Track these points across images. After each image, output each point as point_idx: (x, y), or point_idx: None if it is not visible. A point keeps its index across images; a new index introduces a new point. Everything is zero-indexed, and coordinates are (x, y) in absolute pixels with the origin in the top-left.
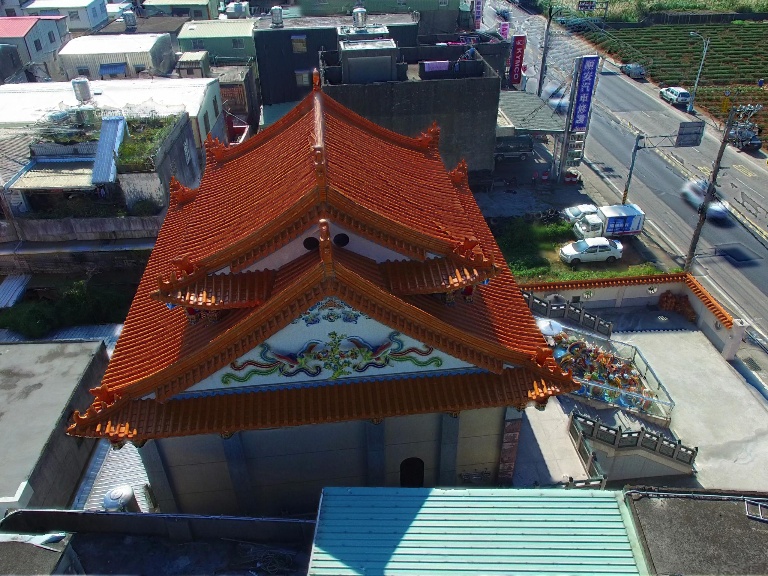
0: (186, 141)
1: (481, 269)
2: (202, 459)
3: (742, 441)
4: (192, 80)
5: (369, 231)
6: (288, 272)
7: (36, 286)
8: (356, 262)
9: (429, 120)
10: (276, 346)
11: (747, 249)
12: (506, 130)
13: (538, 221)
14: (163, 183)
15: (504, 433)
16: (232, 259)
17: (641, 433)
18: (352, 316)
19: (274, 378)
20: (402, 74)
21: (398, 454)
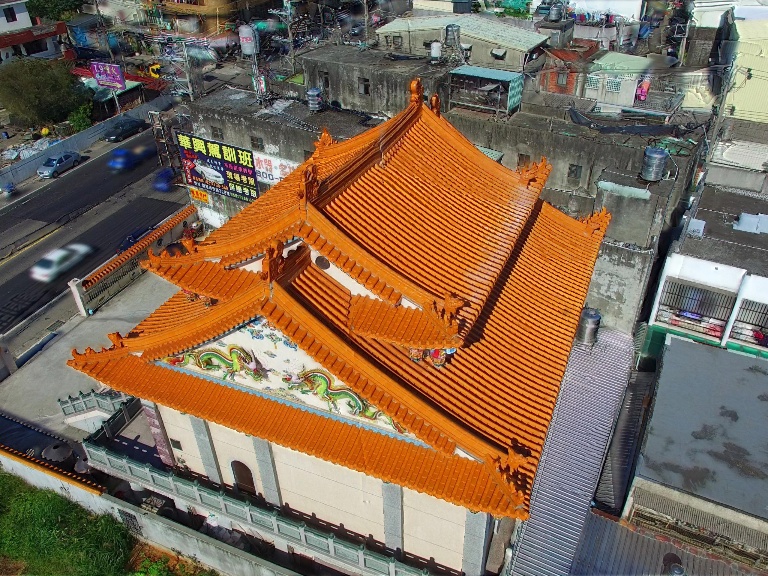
0: None
1: None
2: None
3: (124, 320)
4: None
5: None
6: None
7: None
8: None
9: None
10: None
11: None
12: None
13: None
14: None
15: None
16: None
17: None
18: None
19: None
20: None
21: None
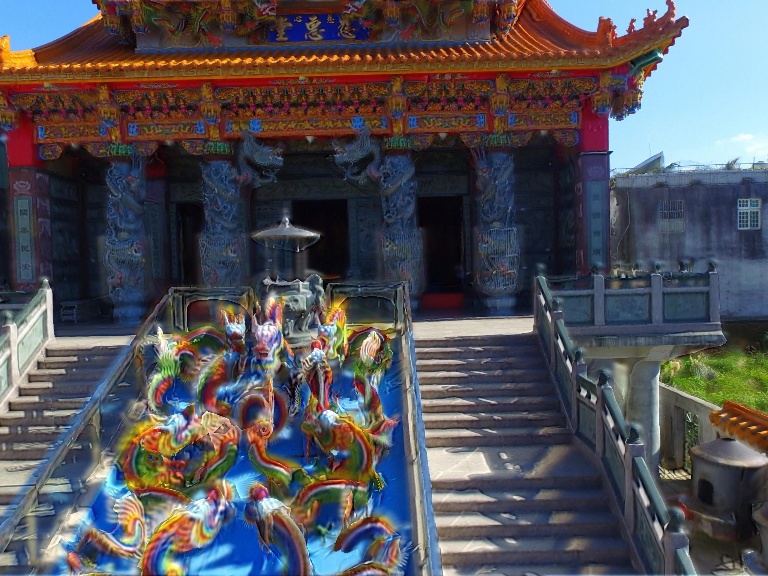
0: (759, 202)
1: None
2: None
3: None
4: None
5: None
6: None
7: None
8: None
9: None
10: None
11: None
12: None
13: None
14: (624, 208)
15: None
16: None
17: None
18: None
19: None
20: None
21: None
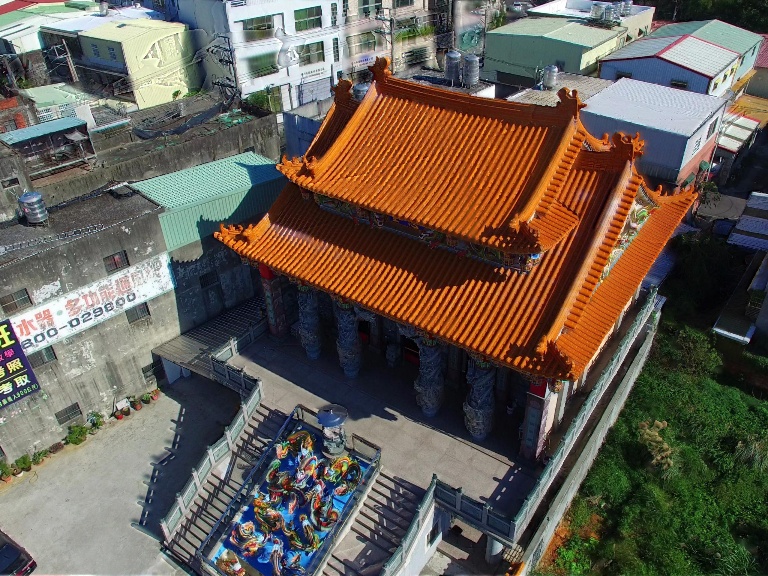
0: None
1: None
2: None
3: None
4: None
5: None
6: None
7: (757, 254)
8: None
9: None
10: None
11: None
12: None
13: None
14: None
15: None
16: None
17: None
18: None
19: None
20: None
21: None
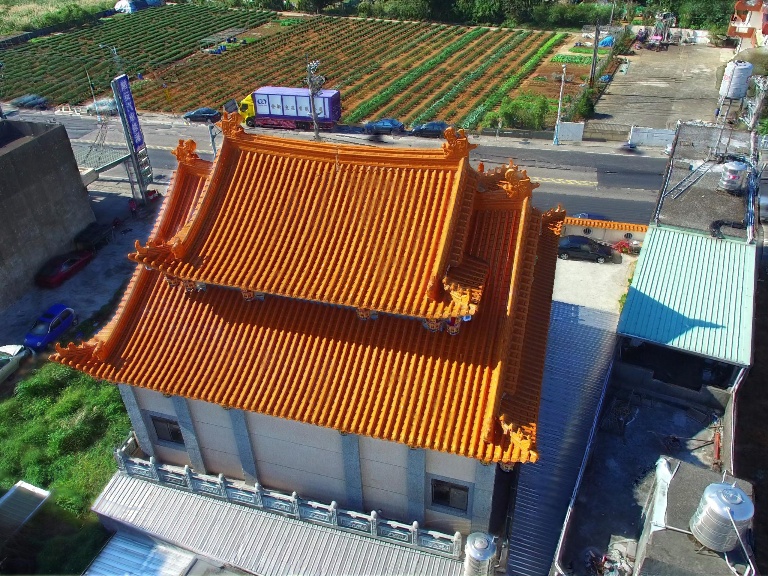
0: None
1: None
2: None
3: None
4: None
5: None
6: (471, 242)
7: None
8: None
9: (21, 199)
10: None
11: None
12: (89, 176)
13: None
14: None
15: None
16: (448, 258)
17: None
18: None
19: None
20: None
21: None
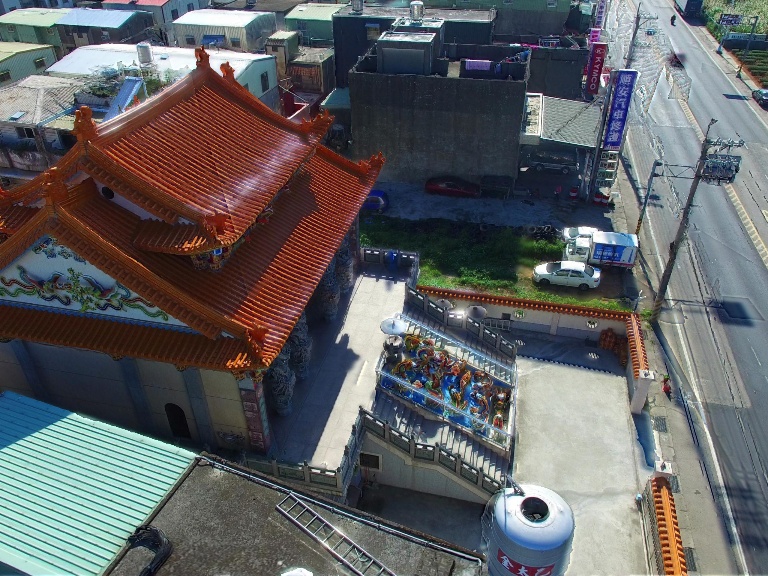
0: None
1: (209, 239)
2: (5, 358)
3: (582, 494)
4: (252, 55)
5: (123, 188)
6: None
7: None
8: (115, 214)
9: (450, 118)
10: (31, 271)
11: (751, 306)
12: (531, 138)
13: (528, 235)
14: None
15: (243, 401)
16: (29, 194)
17: (435, 448)
18: (81, 257)
19: (37, 299)
20: (442, 69)
21: (160, 397)
